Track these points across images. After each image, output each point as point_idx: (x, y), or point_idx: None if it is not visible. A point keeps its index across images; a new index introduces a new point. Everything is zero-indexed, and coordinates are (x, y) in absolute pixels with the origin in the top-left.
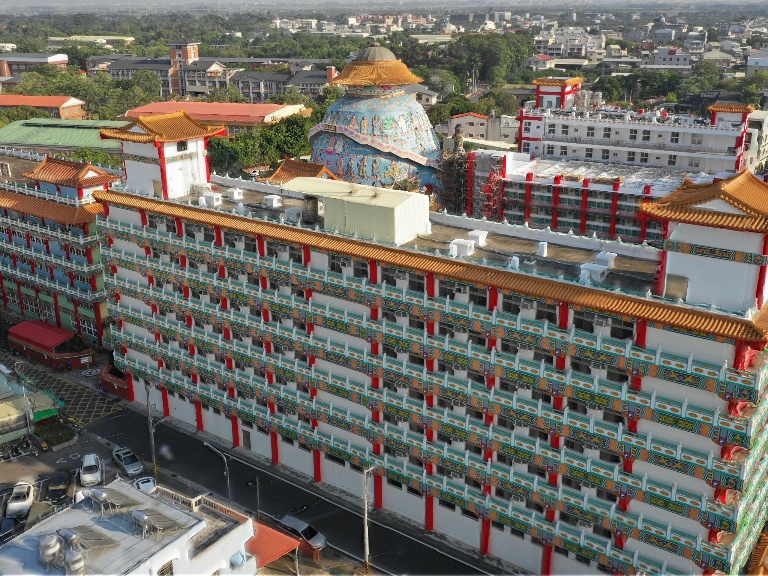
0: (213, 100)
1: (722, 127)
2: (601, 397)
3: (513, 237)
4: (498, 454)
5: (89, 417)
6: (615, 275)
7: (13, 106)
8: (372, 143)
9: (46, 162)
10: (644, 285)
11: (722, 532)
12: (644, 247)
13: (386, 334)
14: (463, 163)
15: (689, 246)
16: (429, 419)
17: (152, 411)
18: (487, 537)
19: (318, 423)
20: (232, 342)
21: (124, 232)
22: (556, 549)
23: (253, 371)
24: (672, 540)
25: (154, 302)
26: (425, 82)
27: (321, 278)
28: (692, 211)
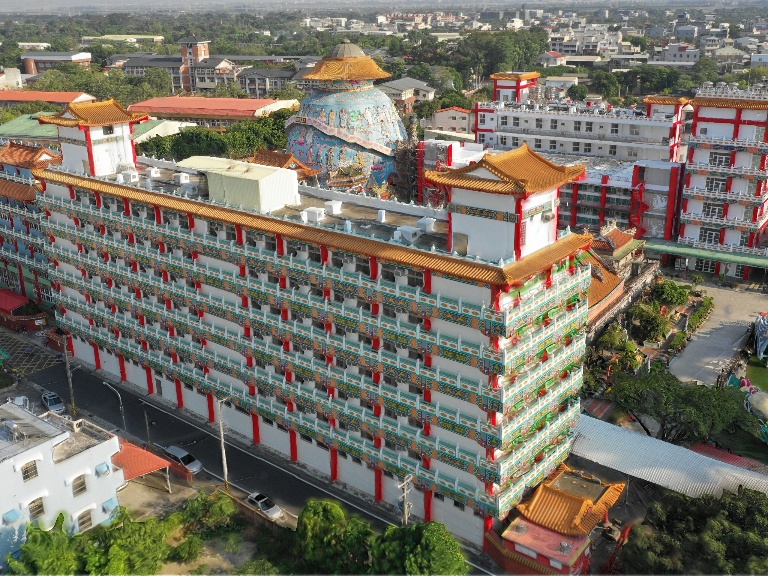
0: (215, 96)
1: (655, 118)
2: (402, 337)
3: (368, 207)
4: (339, 391)
5: (32, 369)
6: (427, 236)
7: (29, 101)
8: (338, 134)
9: (10, 147)
10: (447, 244)
11: (502, 452)
12: None
13: (250, 288)
14: (416, 152)
15: (465, 208)
16: (285, 362)
17: (69, 358)
18: (336, 465)
19: (209, 370)
20: (141, 300)
21: (57, 205)
22: (385, 473)
23: (159, 326)
24: (460, 458)
25: (82, 267)
26: (425, 78)
27: (201, 241)
28: (463, 178)
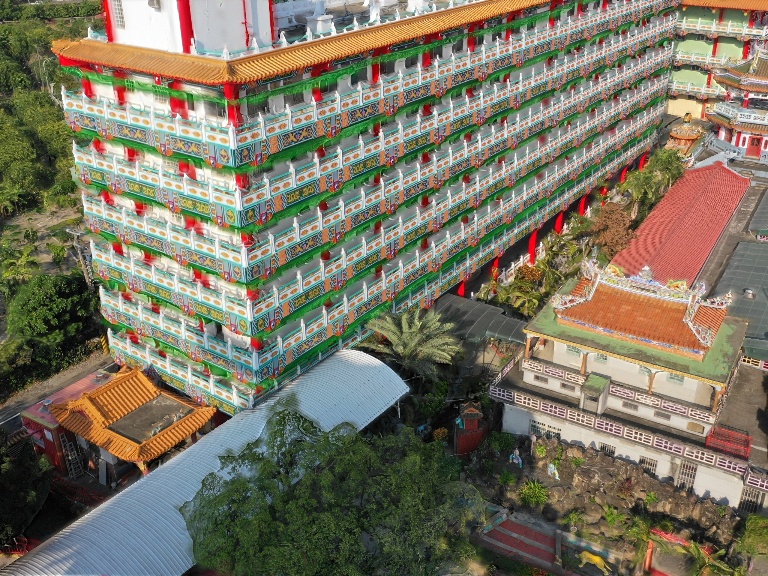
0: None
1: None
2: None
3: None
4: None
5: None
6: None
7: None
8: None
9: None
10: None
11: (135, 296)
12: None
13: None
14: None
15: None
16: None
17: None
18: None
19: None
20: None
21: None
22: None
23: None
24: None
25: None
26: None
27: None
28: None
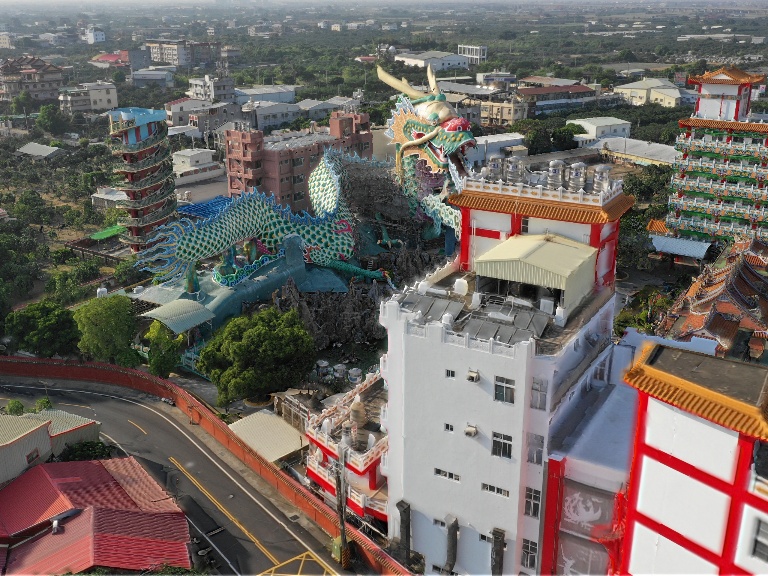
0: None
1: None
2: None
3: None
4: None
5: None
6: None
7: None
8: None
9: None
10: None
11: None
12: (762, 123)
13: None
14: None
15: None
16: None
17: None
18: None
19: None
20: None
21: None
22: None
23: None
24: None
25: None
26: None
27: None
28: None
